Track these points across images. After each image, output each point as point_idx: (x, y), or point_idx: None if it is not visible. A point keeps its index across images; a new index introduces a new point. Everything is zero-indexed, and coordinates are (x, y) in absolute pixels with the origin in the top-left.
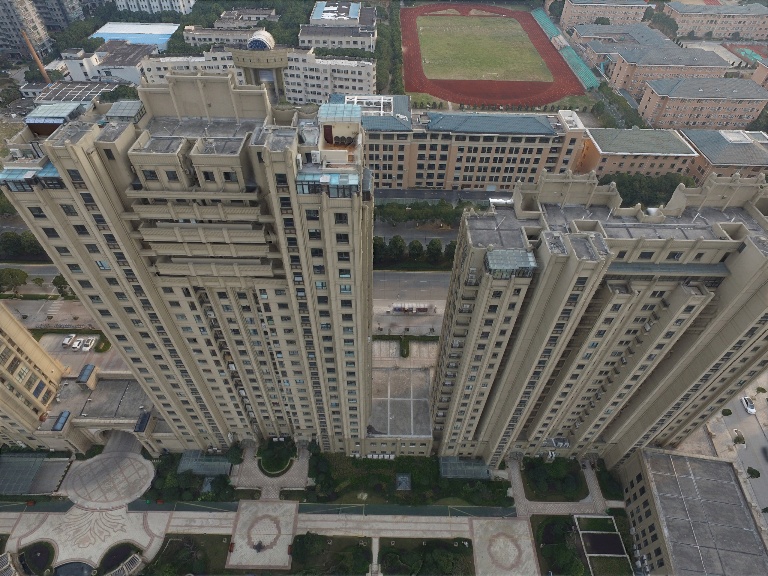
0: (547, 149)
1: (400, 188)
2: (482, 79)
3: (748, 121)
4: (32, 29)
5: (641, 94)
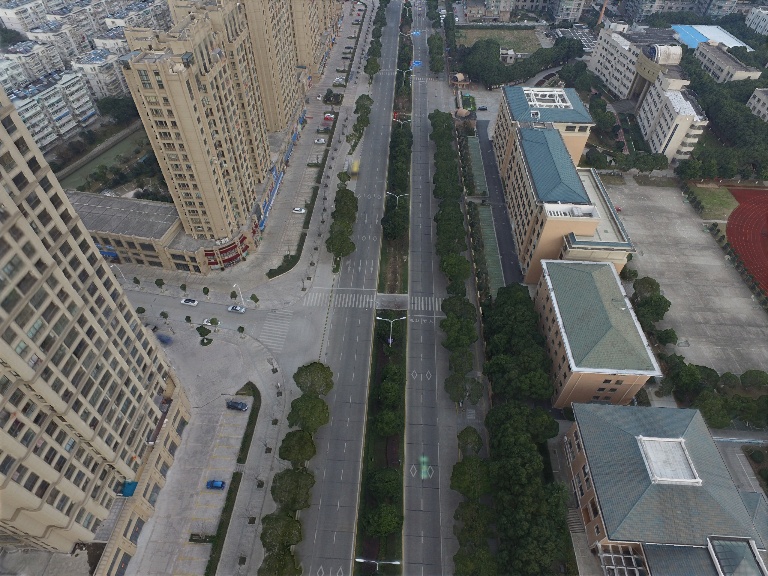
0: None
1: None
2: None
3: None
4: (649, 1)
5: None
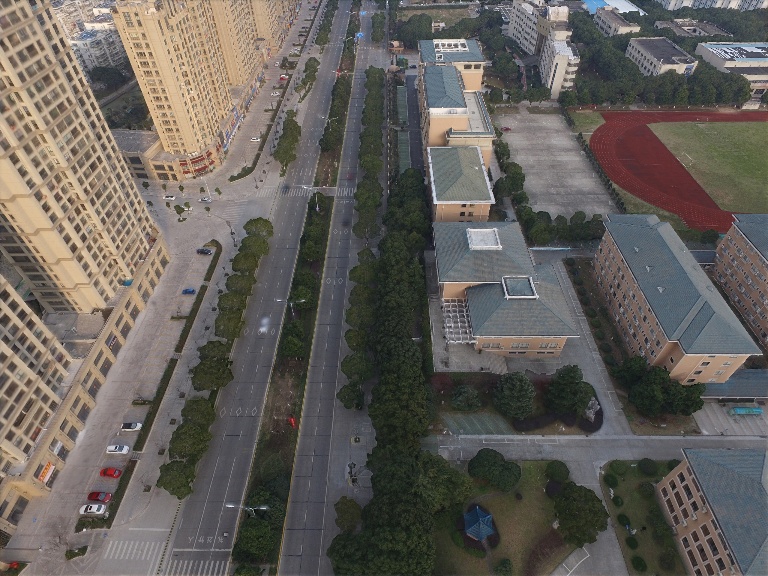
0: None
1: None
2: (677, 155)
3: (651, 360)
4: None
5: (725, 280)
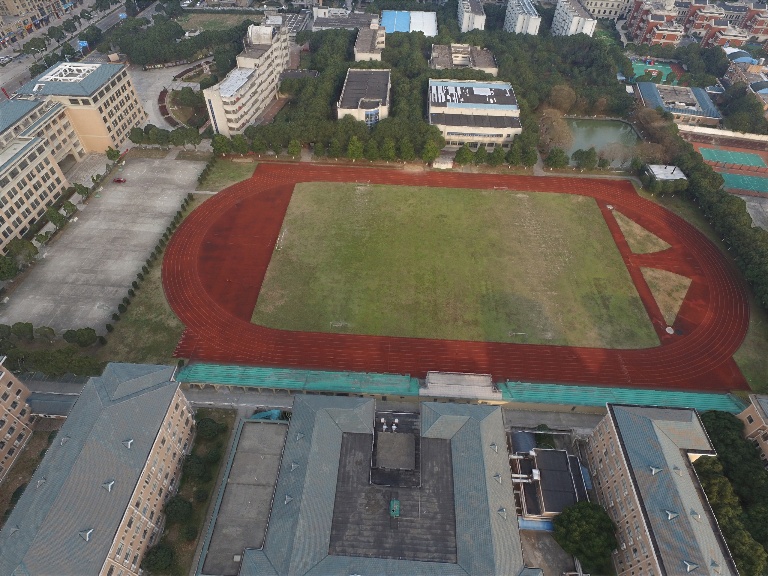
0: None
1: None
2: None
3: None
4: None
5: None
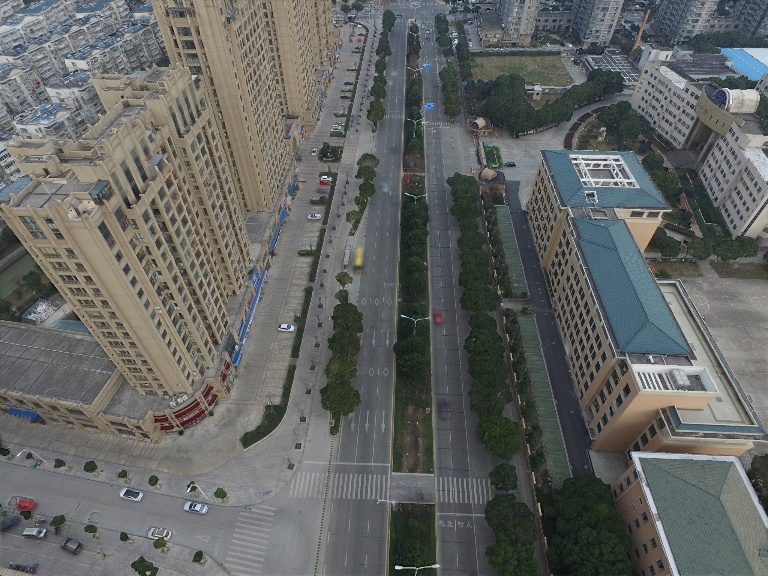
0: (608, 364)
1: (541, 261)
2: None
3: None
4: (691, 21)
5: None
